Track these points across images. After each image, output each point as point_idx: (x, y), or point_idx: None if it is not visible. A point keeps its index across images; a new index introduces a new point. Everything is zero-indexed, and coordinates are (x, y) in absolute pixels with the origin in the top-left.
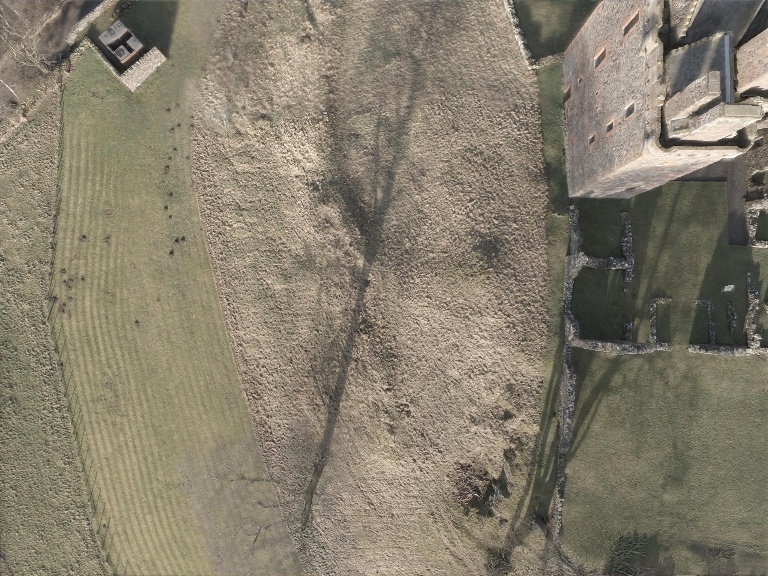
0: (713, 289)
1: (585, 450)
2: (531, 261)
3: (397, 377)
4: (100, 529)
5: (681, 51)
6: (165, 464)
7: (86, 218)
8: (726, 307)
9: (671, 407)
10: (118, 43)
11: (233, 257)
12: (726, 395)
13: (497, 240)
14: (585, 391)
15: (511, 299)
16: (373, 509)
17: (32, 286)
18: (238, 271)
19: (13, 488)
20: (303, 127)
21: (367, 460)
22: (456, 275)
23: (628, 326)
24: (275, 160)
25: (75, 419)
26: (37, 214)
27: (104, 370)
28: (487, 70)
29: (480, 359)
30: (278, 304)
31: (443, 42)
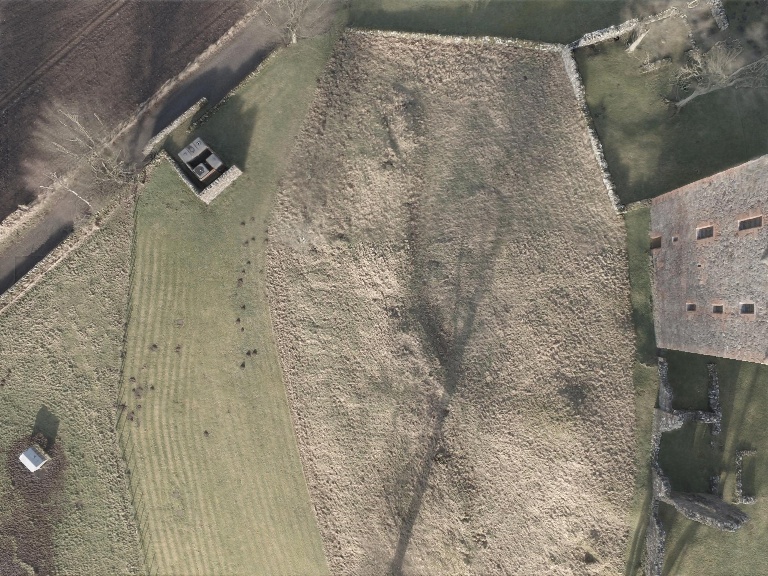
0: None
1: None
2: (618, 410)
3: (474, 508)
4: None
5: None
6: (231, 574)
7: (157, 327)
8: None
9: (753, 557)
10: (196, 159)
11: (305, 372)
12: None
13: (583, 385)
14: (671, 542)
15: (598, 447)
16: None
17: (101, 393)
18: (310, 386)
19: None
20: (383, 253)
21: None
22: (540, 416)
23: (715, 480)
24: (352, 281)
25: (141, 527)
26: (107, 322)
27: (172, 479)
28: (574, 211)
29: (563, 501)
30: (351, 422)
31: (530, 180)
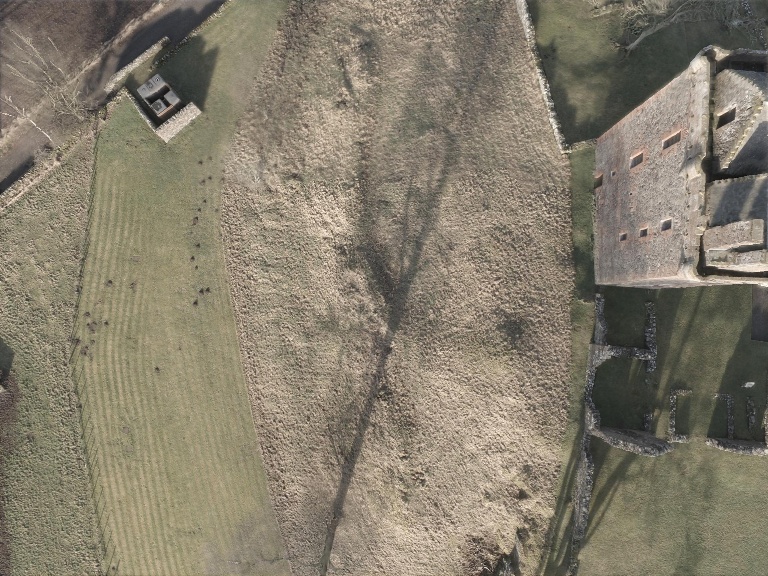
0: (733, 383)
1: (599, 537)
2: (555, 345)
3: (414, 445)
4: (109, 571)
5: (723, 184)
6: (177, 511)
7: (113, 263)
8: (745, 402)
9: (686, 498)
10: (155, 96)
11: (256, 311)
12: (741, 489)
13: (522, 321)
14: (602, 478)
15: (533, 382)
16: (382, 572)
17: (56, 327)
18: (260, 325)
19: (25, 526)
20: (334, 191)
21: (379, 524)
22: (479, 352)
23: (648, 417)
24: (304, 220)
25: (90, 461)
26: (65, 256)
27: (122, 414)
28: (520, 150)
29: (498, 437)
30: (298, 361)
31: (478, 119)
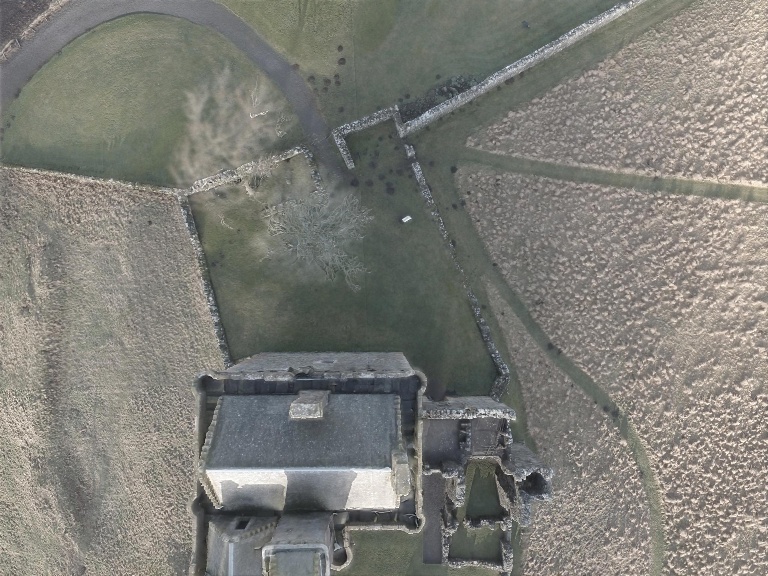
0: None
1: None
2: None
3: None
4: None
5: (212, 529)
6: None
7: None
8: None
9: None
10: None
11: None
12: None
13: None
14: None
15: None
16: None
17: None
18: None
19: None
20: (23, 402)
21: None
22: None
23: None
24: (5, 426)
25: None
26: None
27: None
28: (189, 366)
29: None
30: (13, 570)
31: (148, 333)
